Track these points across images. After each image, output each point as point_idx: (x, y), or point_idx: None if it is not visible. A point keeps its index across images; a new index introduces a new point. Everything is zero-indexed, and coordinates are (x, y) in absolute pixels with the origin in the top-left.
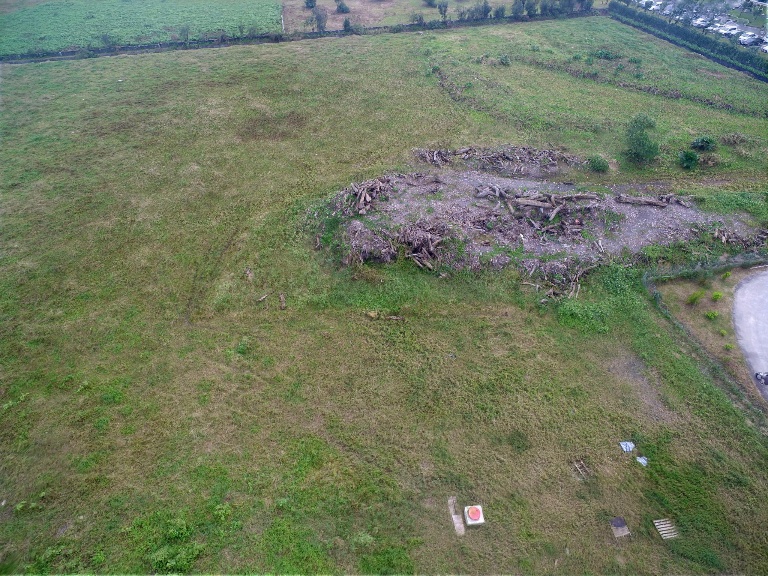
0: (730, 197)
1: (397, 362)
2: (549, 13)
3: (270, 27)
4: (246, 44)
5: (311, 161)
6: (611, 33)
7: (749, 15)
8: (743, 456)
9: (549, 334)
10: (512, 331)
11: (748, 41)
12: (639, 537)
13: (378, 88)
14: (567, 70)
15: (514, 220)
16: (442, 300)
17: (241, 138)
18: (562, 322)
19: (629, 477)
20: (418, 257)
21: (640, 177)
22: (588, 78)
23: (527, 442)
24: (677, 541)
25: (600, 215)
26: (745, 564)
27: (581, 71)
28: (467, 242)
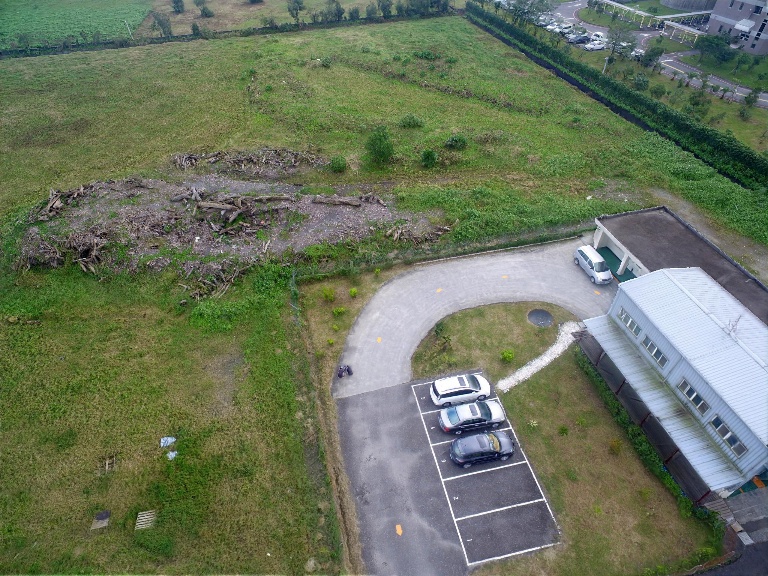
0: (431, 195)
1: (3, 366)
2: (405, 14)
3: (123, 33)
4: (90, 50)
5: (65, 168)
6: (450, 33)
7: (596, 13)
8: (268, 447)
9: (171, 334)
10: (137, 332)
11: (574, 39)
12: (113, 529)
13: (185, 93)
14: (382, 71)
15: (194, 223)
16: (90, 303)
17: (13, 146)
18: (191, 322)
19: (144, 471)
20: (84, 262)
21: (375, 177)
22: (397, 79)
23: (73, 441)
24: (144, 531)
25: (287, 216)
26: (192, 551)
27: (393, 72)
28: (131, 246)
